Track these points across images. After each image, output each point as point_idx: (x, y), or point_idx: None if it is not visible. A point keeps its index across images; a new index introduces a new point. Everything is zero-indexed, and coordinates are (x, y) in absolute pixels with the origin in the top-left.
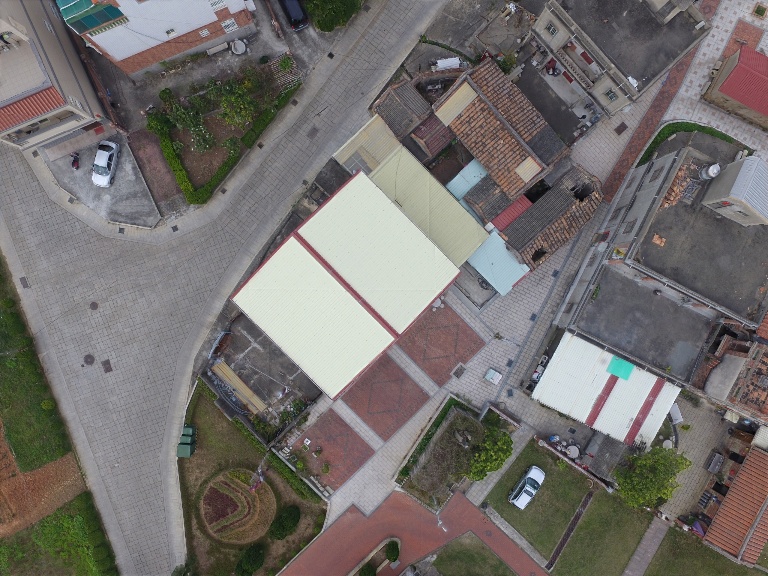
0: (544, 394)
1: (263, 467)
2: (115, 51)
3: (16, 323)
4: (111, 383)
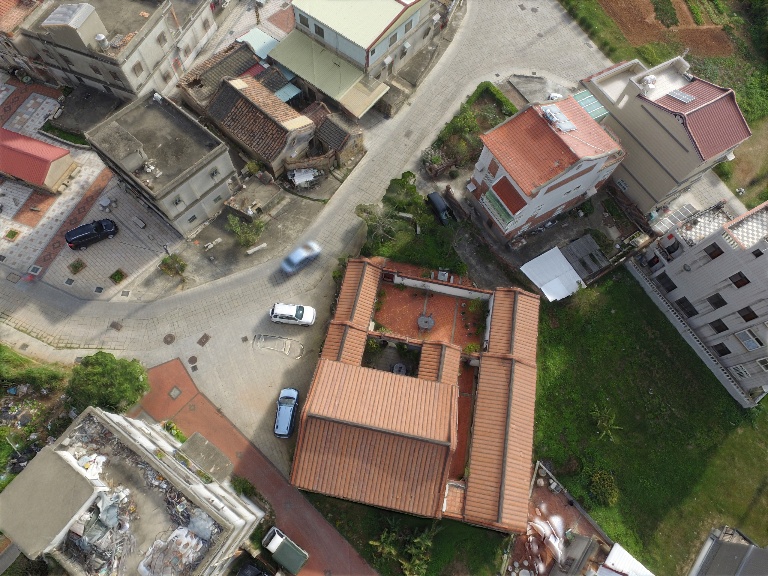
0: None
1: None
2: None
3: (586, 22)
4: None
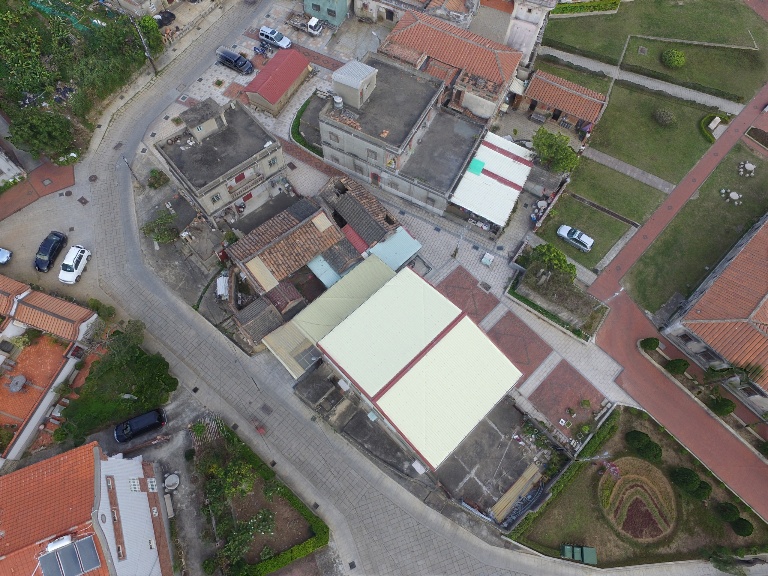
0: (500, 218)
1: (593, 470)
2: None
3: None
4: None
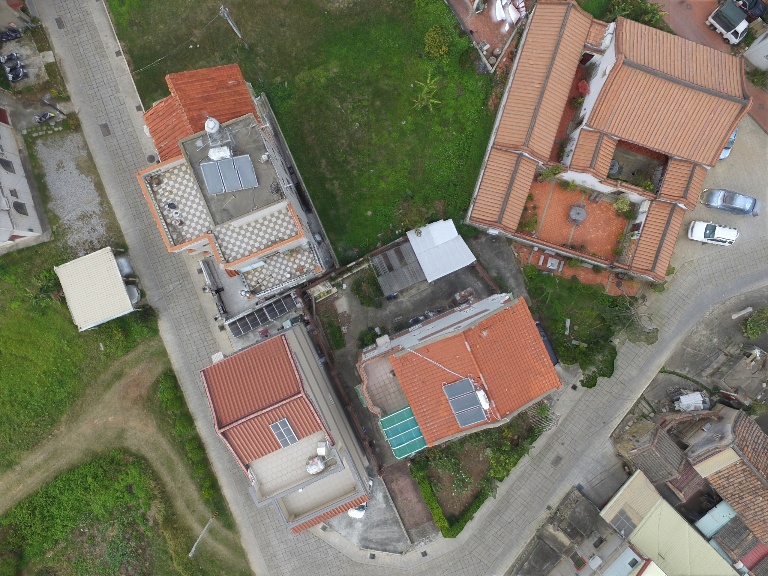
0: None
1: None
2: None
3: None
4: None
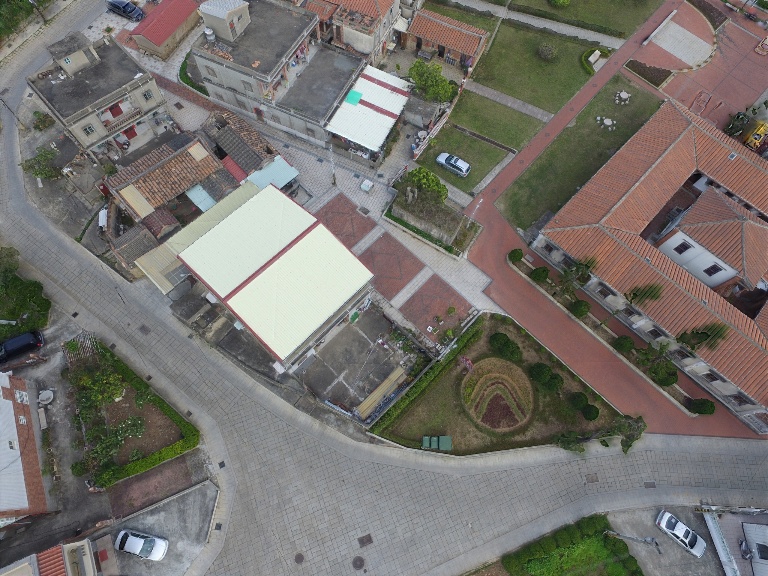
0: (374, 143)
1: (458, 371)
2: (16, 503)
3: None
4: (383, 535)
